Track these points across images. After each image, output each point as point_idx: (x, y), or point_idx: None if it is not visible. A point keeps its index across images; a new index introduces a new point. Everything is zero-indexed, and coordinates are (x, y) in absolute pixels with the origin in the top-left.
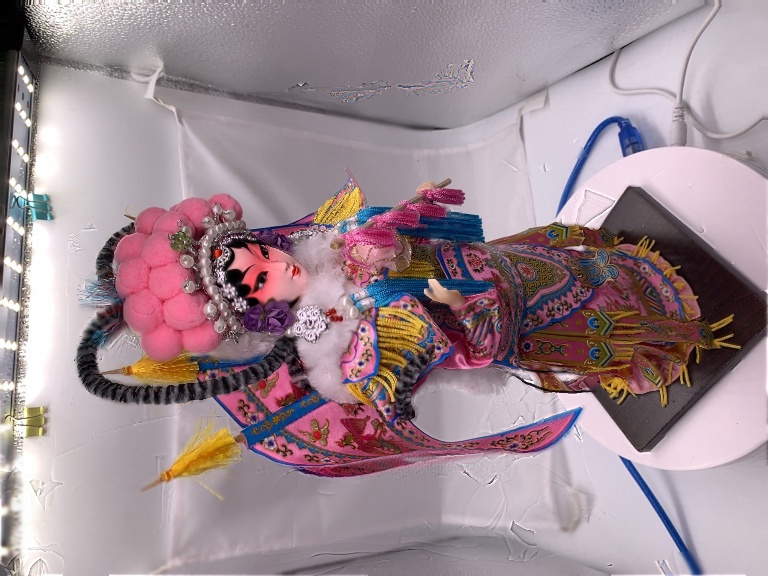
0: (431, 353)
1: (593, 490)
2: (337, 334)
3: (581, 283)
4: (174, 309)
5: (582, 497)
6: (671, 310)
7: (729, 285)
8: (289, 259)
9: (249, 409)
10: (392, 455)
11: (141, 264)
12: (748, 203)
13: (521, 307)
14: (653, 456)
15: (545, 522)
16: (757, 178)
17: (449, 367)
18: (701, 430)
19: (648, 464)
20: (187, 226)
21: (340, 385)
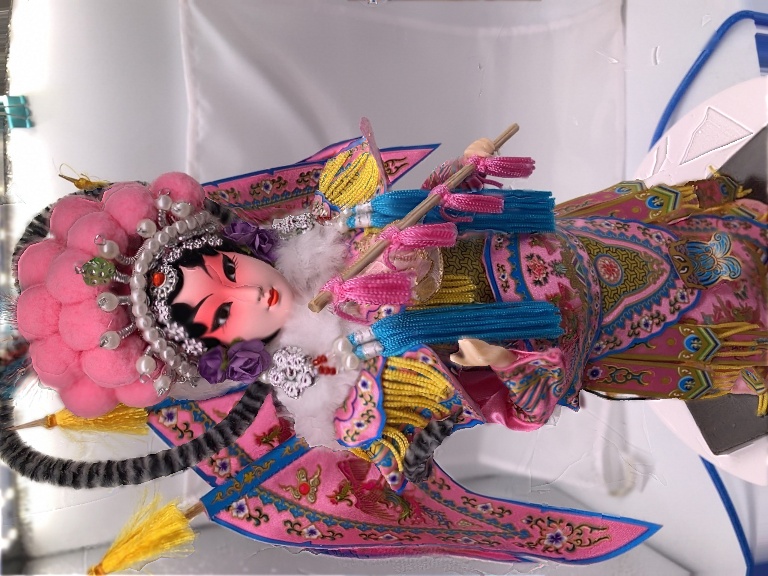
0: None
1: (647, 447)
2: (328, 389)
3: (684, 282)
4: (92, 368)
5: (633, 451)
6: None
7: None
8: (265, 280)
9: (218, 455)
10: (392, 546)
11: (46, 299)
12: None
13: (594, 327)
14: (731, 460)
15: (587, 483)
16: None
17: None
18: None
19: (723, 467)
20: (112, 240)
21: (333, 441)
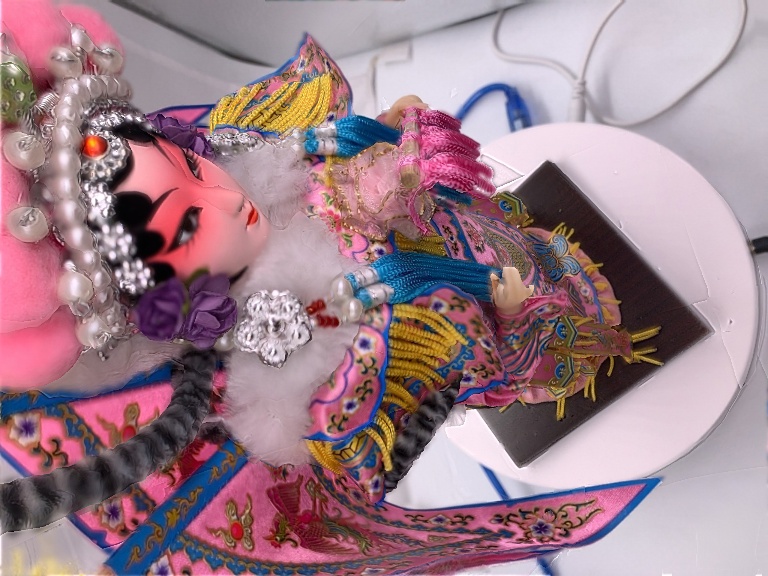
0: None
1: None
2: (321, 350)
3: (544, 276)
4: None
5: None
6: (591, 313)
7: (659, 293)
8: (238, 187)
9: None
10: (397, 574)
11: None
12: (684, 204)
13: None
14: (529, 471)
15: None
16: (698, 178)
17: None
18: (596, 448)
19: (523, 480)
20: (16, 56)
21: (298, 441)
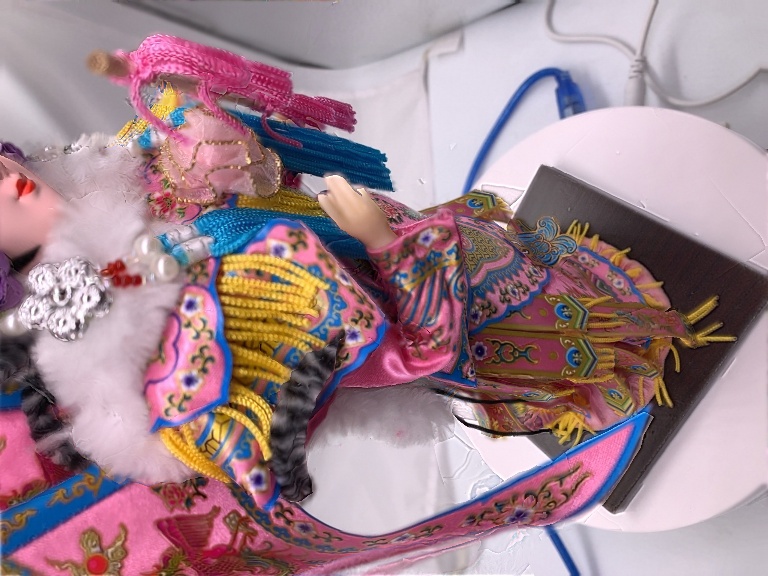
0: (338, 349)
1: None
2: (130, 316)
3: (531, 260)
4: None
5: None
6: None
7: (703, 259)
8: (12, 164)
9: None
10: None
11: None
12: (701, 157)
13: None
14: (630, 517)
15: None
16: (706, 125)
17: (370, 381)
18: (696, 466)
19: (625, 530)
20: None
21: (145, 438)
